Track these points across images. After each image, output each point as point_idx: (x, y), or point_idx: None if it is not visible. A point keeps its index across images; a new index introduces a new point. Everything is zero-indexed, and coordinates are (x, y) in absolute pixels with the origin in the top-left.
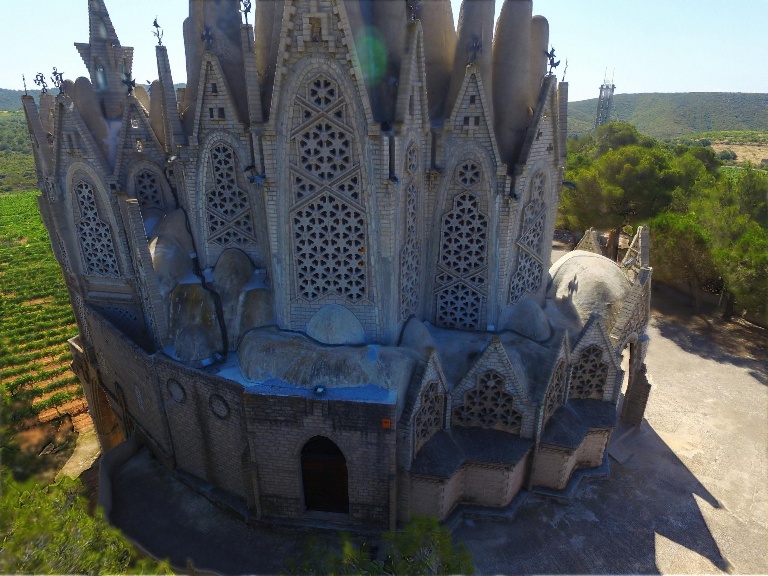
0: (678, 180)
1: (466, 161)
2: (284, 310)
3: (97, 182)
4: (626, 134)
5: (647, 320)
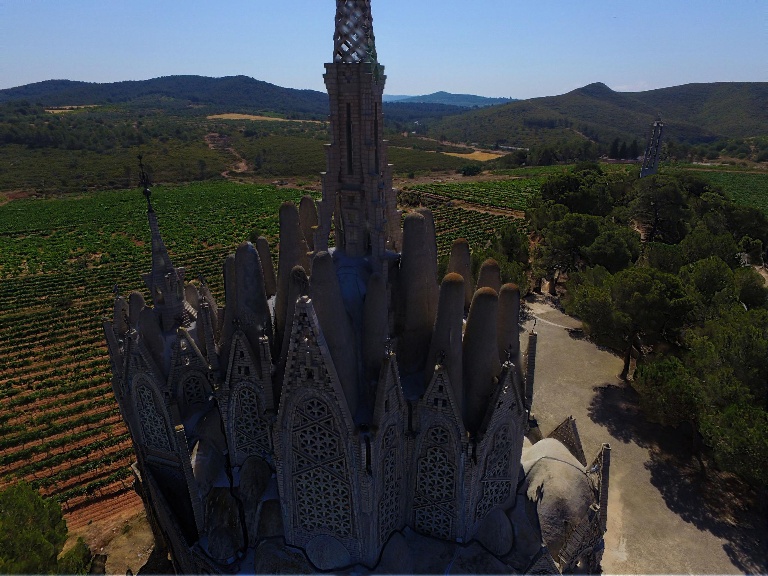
0: (689, 308)
1: (436, 427)
2: (289, 532)
3: (155, 388)
4: (669, 190)
5: (601, 534)
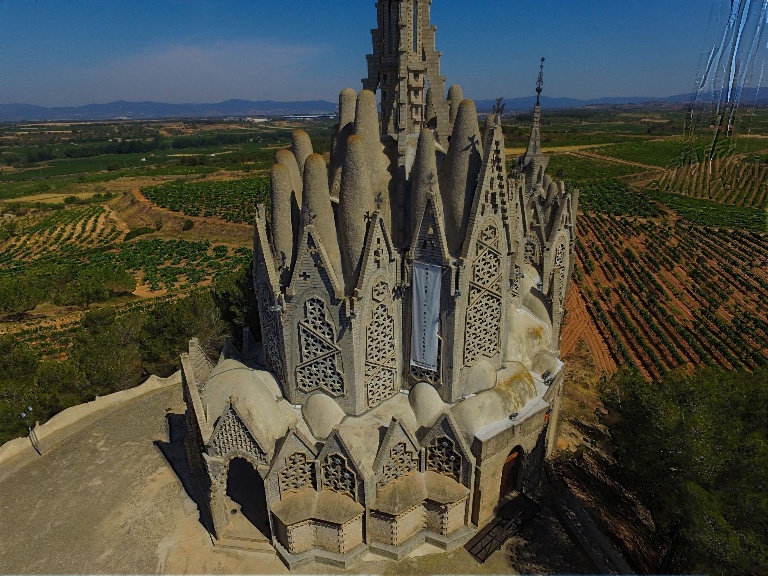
0: None
1: None
2: None
3: None
4: None
5: None
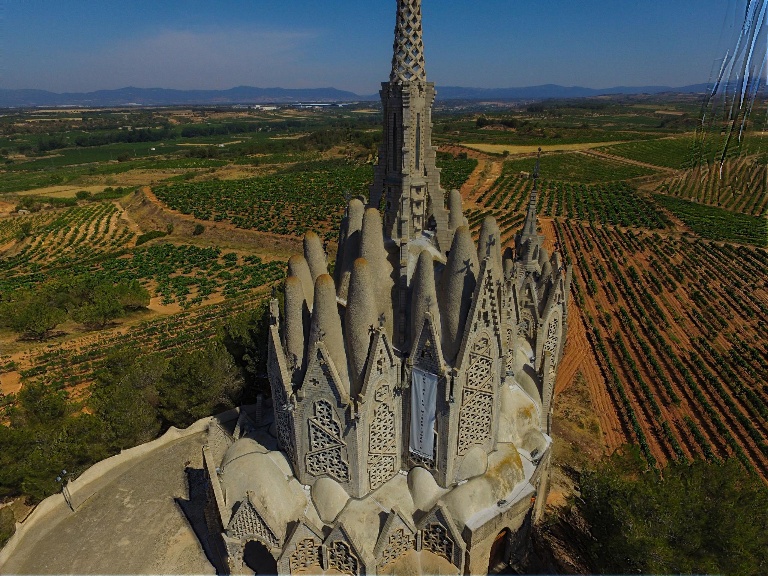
0: None
1: None
2: None
3: None
4: None
5: None
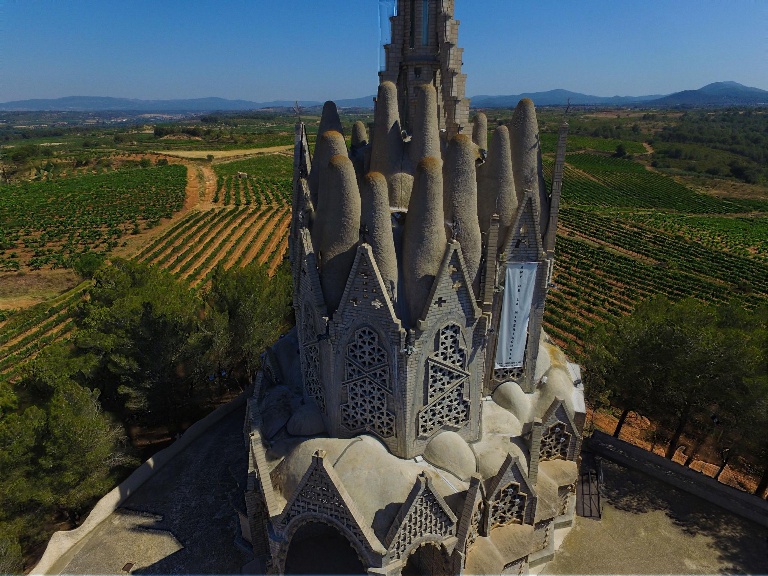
0: None
1: None
2: None
3: None
4: None
5: None
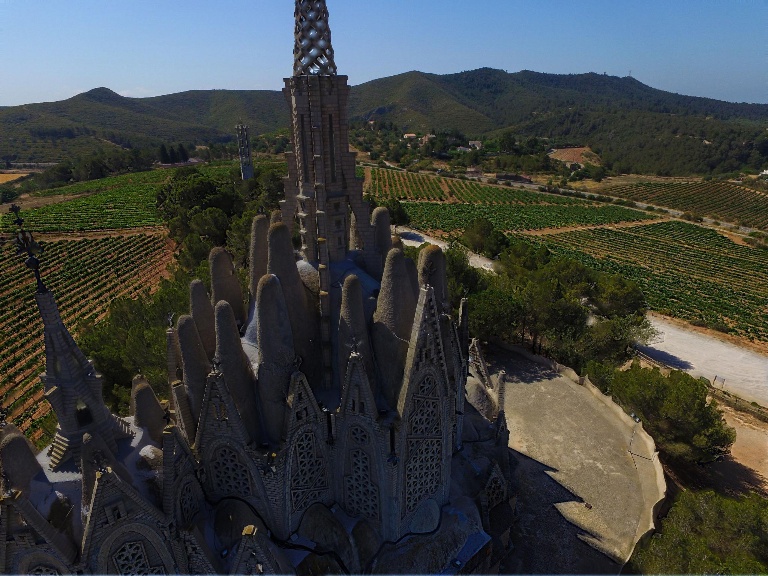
0: None
1: None
2: (397, 528)
3: (148, 533)
4: None
5: None
